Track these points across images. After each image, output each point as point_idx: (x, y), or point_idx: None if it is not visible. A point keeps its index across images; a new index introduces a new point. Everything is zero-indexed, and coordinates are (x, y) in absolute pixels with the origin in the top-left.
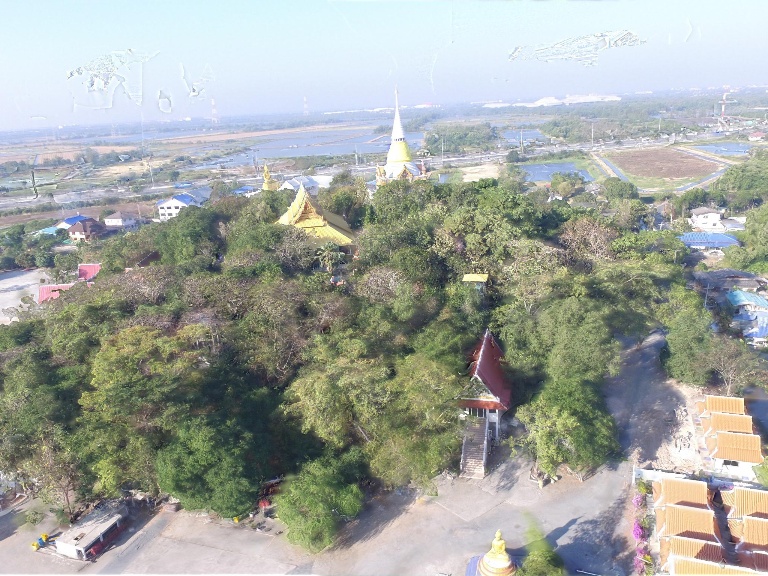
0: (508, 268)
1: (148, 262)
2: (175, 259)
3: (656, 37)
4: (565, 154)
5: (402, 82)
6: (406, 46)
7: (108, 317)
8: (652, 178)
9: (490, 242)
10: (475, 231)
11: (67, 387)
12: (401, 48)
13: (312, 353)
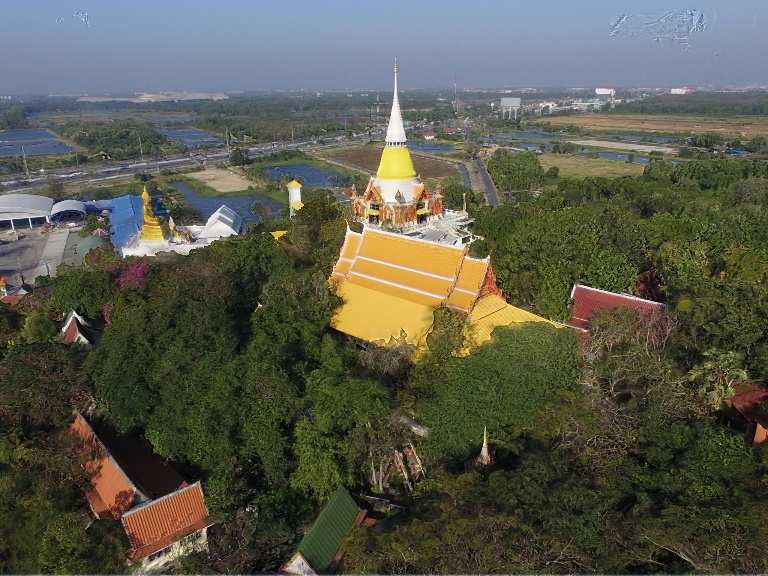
0: None
1: (123, 467)
2: (238, 446)
3: (712, 24)
4: (287, 155)
5: None
6: None
7: None
8: None
9: None
10: None
11: None
12: None
13: None
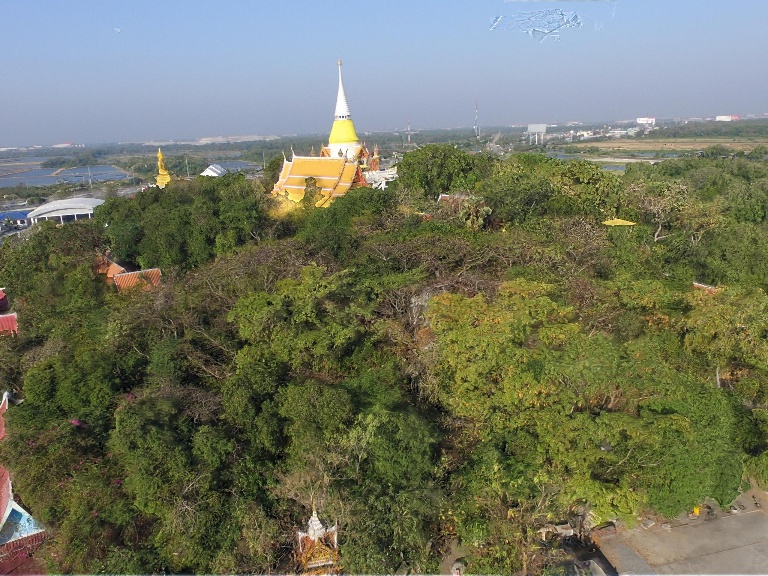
0: (655, 208)
1: None
2: (186, 255)
3: None
4: None
5: (564, 6)
6: None
7: (351, 298)
8: None
9: (603, 190)
10: (583, 181)
11: (395, 403)
12: None
13: (627, 299)
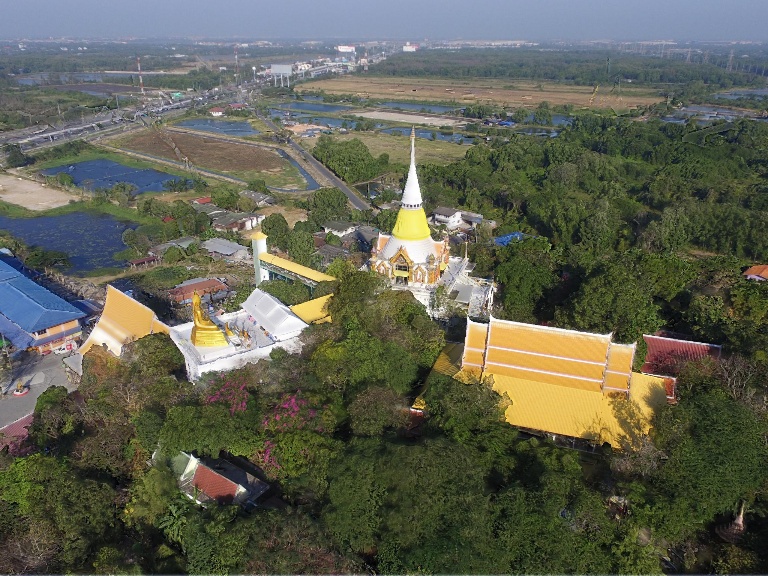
0: None
1: None
2: None
3: None
4: (73, 148)
5: None
6: None
7: None
8: (253, 172)
9: None
10: None
11: None
12: None
13: None
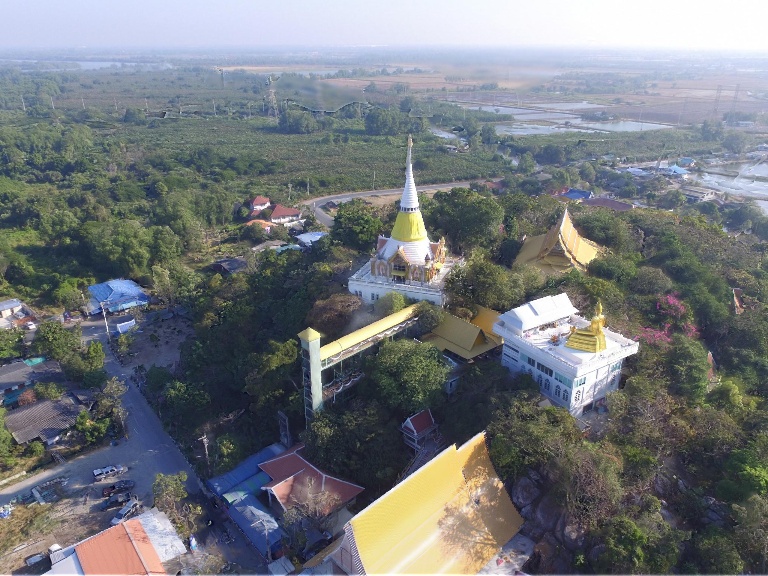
0: None
1: None
2: None
3: (258, 82)
4: None
5: None
6: (528, 89)
7: None
8: None
9: None
10: None
11: None
12: (530, 90)
13: None
